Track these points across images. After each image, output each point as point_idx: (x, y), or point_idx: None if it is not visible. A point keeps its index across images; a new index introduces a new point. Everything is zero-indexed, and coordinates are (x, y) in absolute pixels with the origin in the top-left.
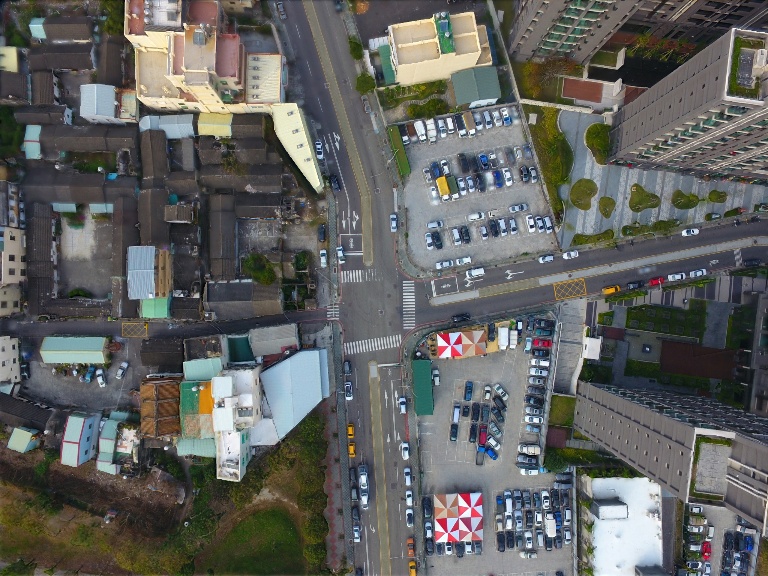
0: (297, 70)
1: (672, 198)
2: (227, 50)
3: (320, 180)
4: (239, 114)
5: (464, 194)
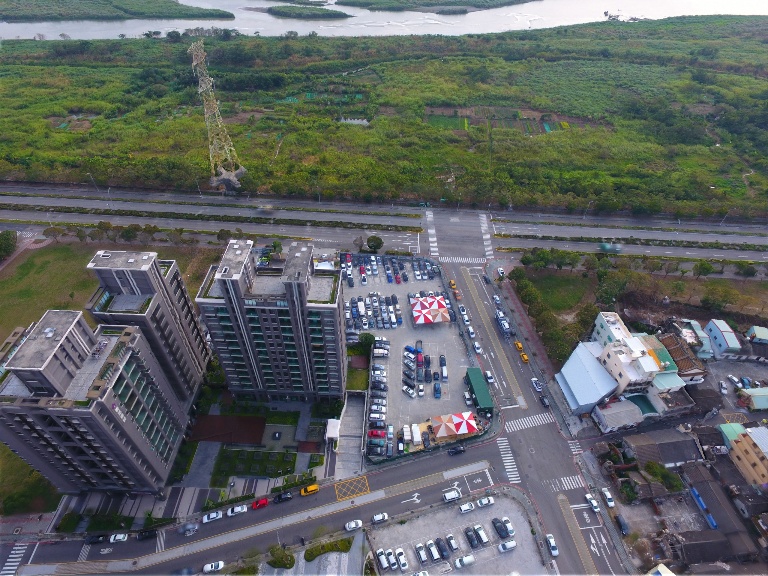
0: None
1: None
2: None
3: None
4: None
5: None
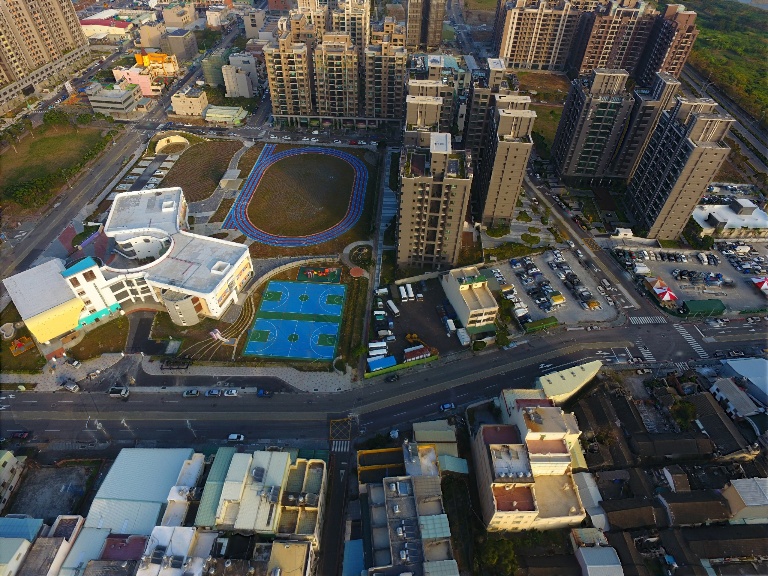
0: (496, 395)
1: (518, 207)
2: None
3: None
4: None
5: None
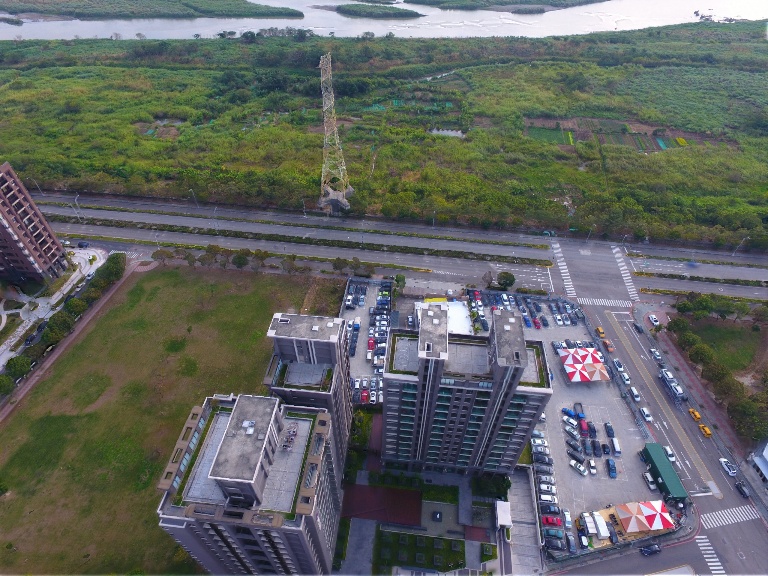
0: None
1: None
2: None
3: None
4: None
5: None
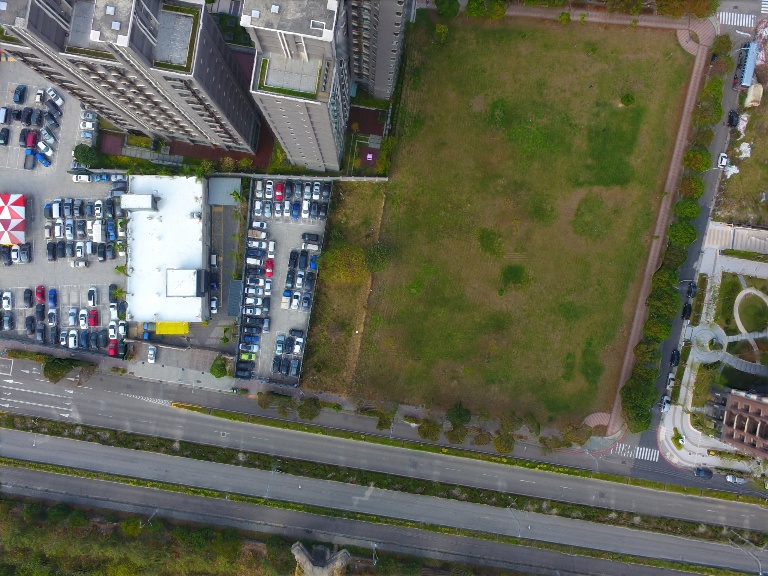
0: None
1: None
2: None
3: None
4: None
5: None
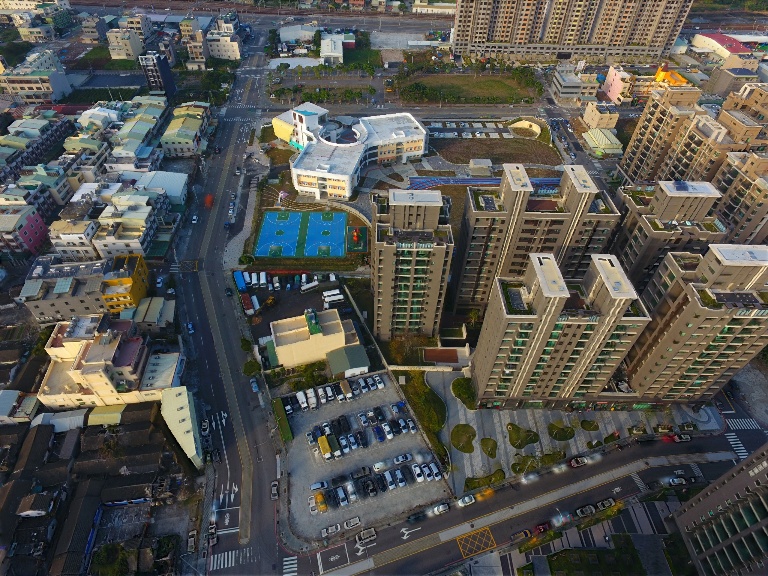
0: (196, 366)
1: (548, 432)
2: (129, 349)
3: (199, 452)
4: (133, 403)
5: (347, 452)
